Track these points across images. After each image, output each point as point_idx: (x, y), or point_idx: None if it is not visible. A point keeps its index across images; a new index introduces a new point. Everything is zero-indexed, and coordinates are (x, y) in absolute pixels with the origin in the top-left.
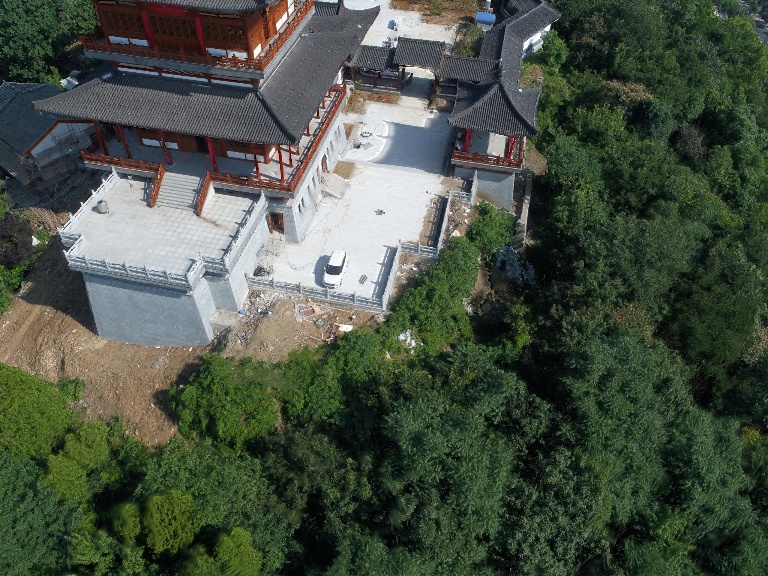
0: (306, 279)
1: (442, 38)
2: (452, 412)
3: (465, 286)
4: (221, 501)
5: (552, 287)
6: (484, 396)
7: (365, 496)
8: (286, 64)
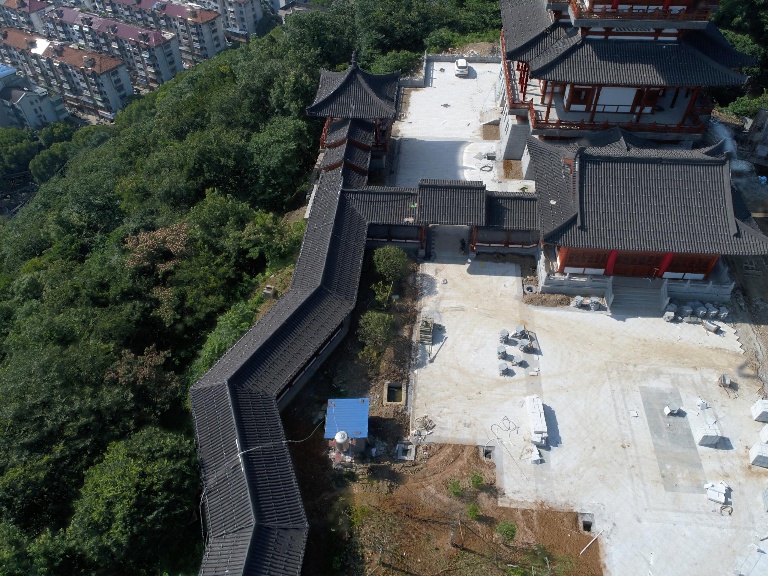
0: (479, 68)
1: (434, 384)
2: (382, 2)
3: (377, 60)
4: (469, 1)
5: (316, 90)
6: (368, 4)
7: (414, 0)
8: (544, 8)
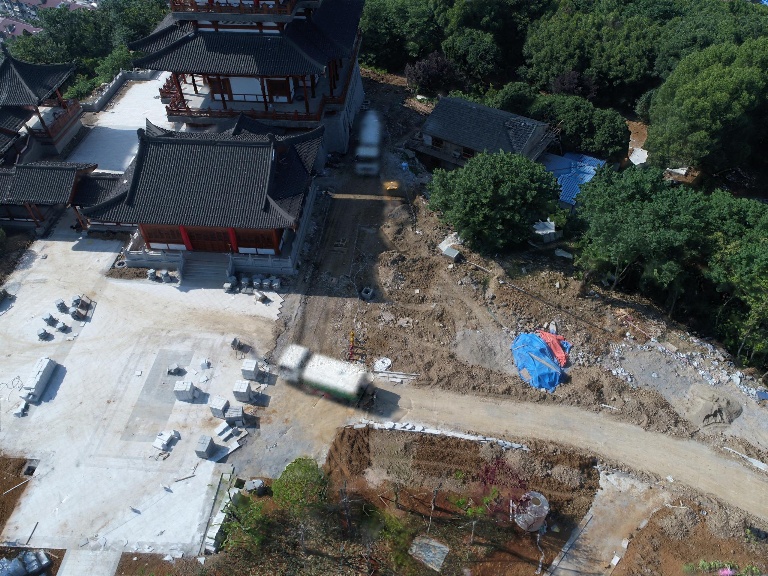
0: None
1: None
2: None
3: None
4: None
5: None
6: (124, 1)
7: None
8: None
